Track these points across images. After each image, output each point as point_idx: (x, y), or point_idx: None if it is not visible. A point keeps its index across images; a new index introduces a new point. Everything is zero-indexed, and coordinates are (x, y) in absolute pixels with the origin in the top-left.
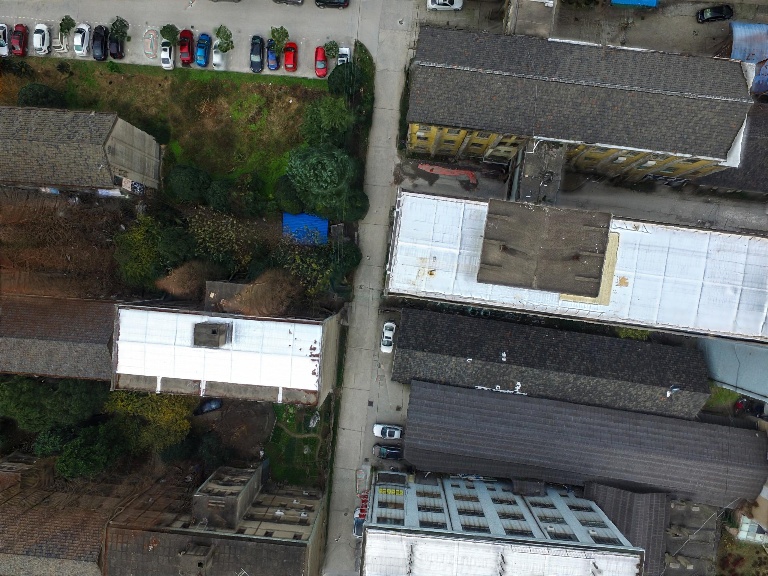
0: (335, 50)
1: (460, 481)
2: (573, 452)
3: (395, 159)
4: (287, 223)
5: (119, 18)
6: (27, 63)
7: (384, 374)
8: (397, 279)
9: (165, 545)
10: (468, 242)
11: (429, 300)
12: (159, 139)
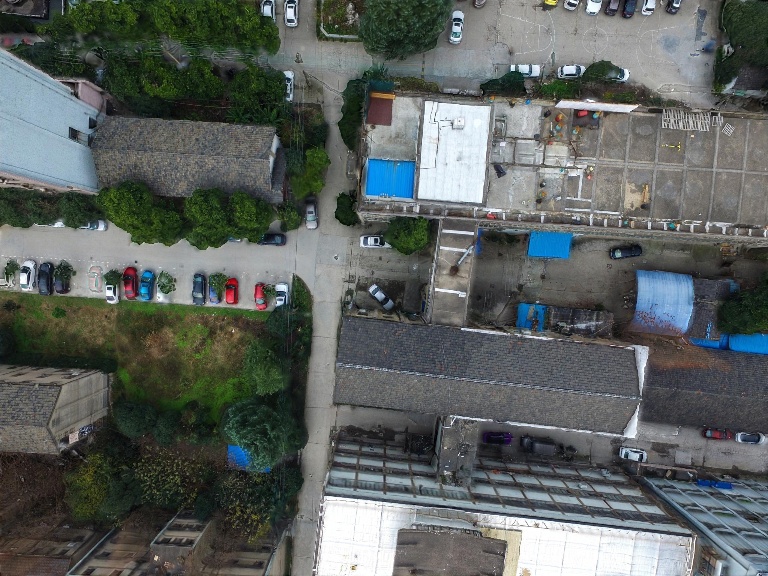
0: (273, 293)
1: None
2: None
3: None
4: (232, 451)
5: (63, 264)
6: None
7: None
8: (322, 574)
9: None
10: (386, 540)
11: None
12: (106, 372)
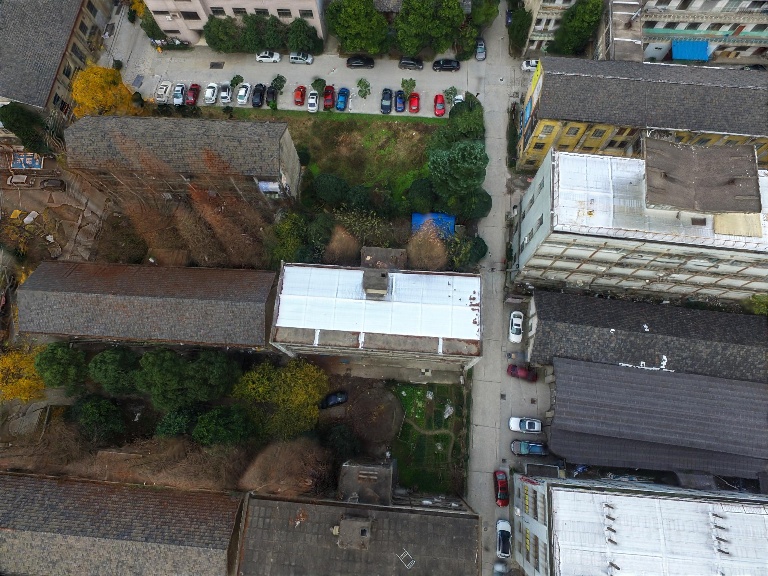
0: (454, 94)
1: (614, 481)
2: (741, 429)
3: (506, 175)
4: (416, 222)
5: (280, 75)
6: None
7: (515, 364)
8: (560, 219)
9: (314, 520)
10: (619, 188)
11: (591, 237)
12: (302, 160)
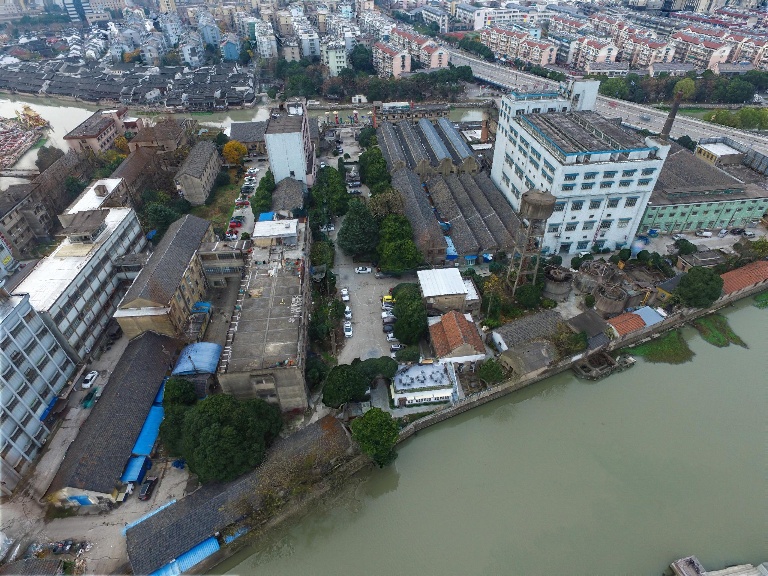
0: None
1: None
2: None
3: None
4: None
5: (251, 187)
6: (243, 178)
7: None
8: None
9: None
10: None
11: None
12: None
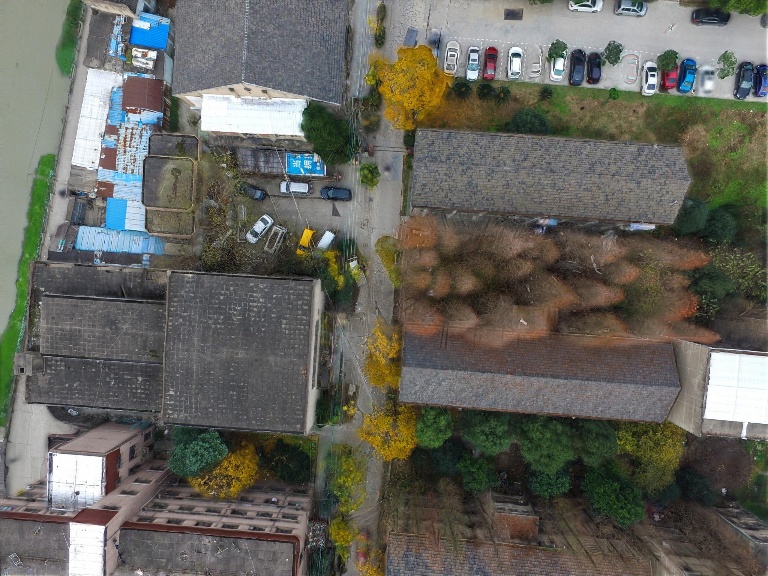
0: None
1: None
2: None
3: None
4: None
5: (617, 43)
6: None
7: None
8: None
9: None
10: None
11: None
12: None
